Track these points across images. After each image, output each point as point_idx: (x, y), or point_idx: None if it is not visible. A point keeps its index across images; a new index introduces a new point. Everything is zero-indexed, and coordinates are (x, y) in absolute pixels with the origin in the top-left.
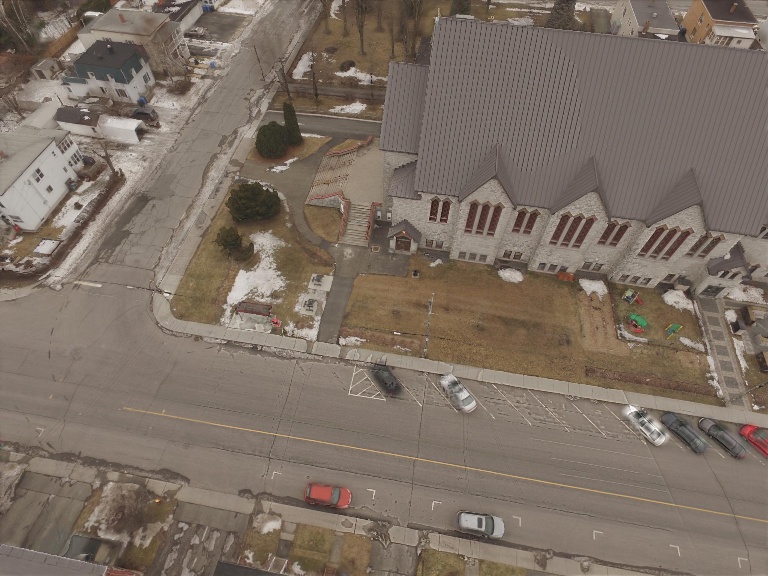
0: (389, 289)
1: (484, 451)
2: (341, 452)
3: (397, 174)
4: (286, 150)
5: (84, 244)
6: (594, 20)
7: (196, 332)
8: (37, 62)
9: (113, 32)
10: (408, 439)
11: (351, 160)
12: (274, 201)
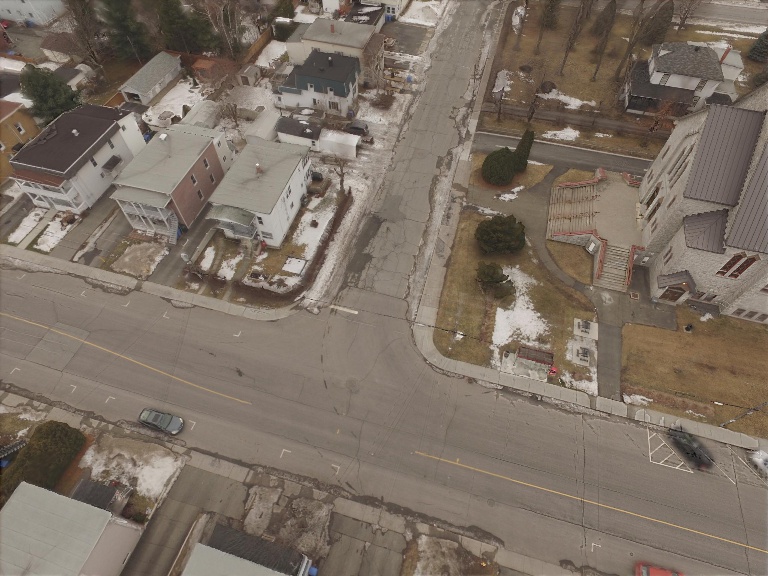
0: (663, 343)
1: None
2: (660, 529)
3: (691, 223)
4: None
5: (329, 265)
6: None
7: (468, 373)
8: (242, 68)
9: (325, 43)
10: (732, 522)
11: (597, 195)
12: (522, 235)
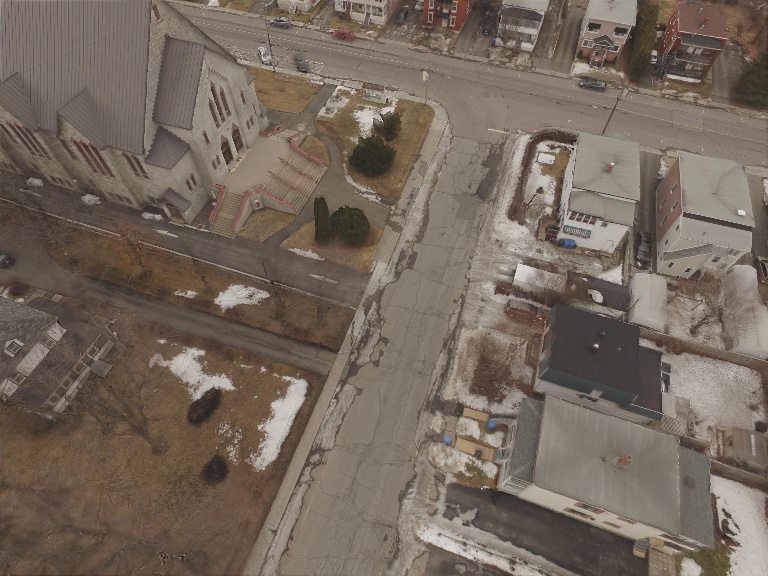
0: (281, 103)
1: (264, 40)
2: (334, 48)
3: None
4: None
5: (517, 159)
6: None
7: (414, 97)
8: None
9: (623, 421)
10: (300, 47)
11: None
12: None
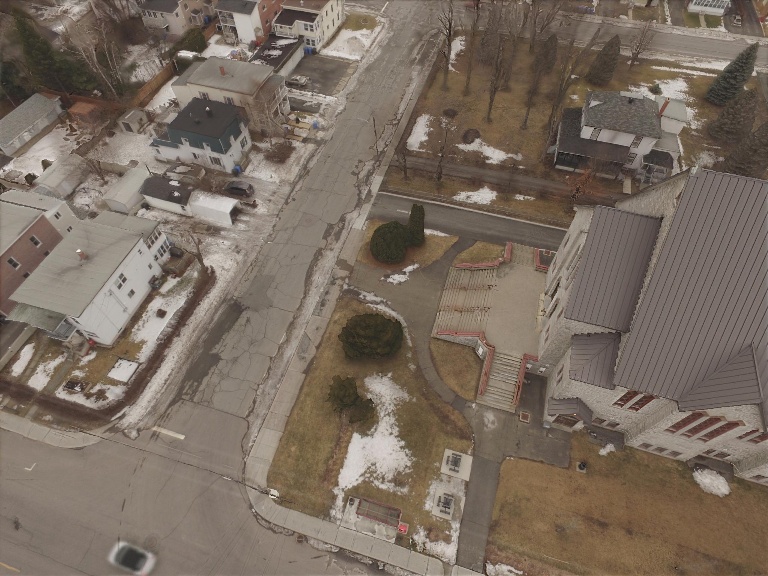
0: (548, 487)
1: None
2: None
3: (579, 344)
4: (405, 254)
5: (166, 370)
6: (764, 89)
7: (299, 529)
8: (125, 112)
9: (211, 87)
10: None
11: (493, 285)
12: (397, 336)
